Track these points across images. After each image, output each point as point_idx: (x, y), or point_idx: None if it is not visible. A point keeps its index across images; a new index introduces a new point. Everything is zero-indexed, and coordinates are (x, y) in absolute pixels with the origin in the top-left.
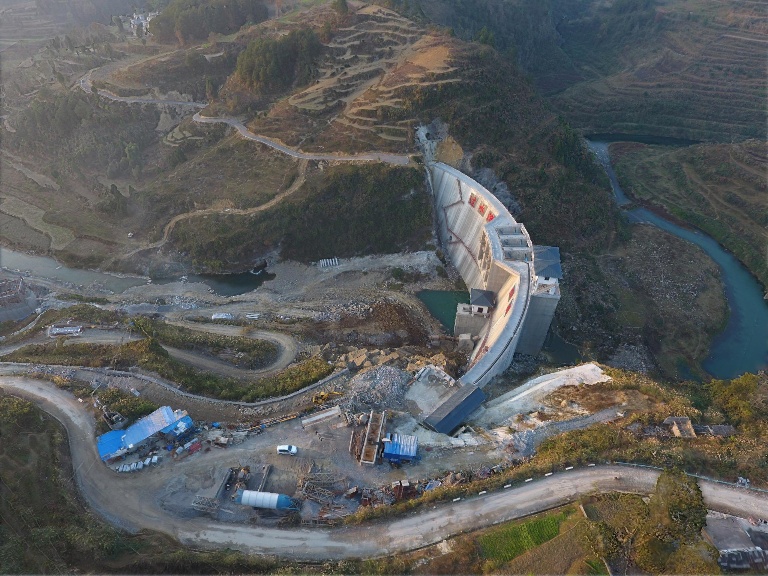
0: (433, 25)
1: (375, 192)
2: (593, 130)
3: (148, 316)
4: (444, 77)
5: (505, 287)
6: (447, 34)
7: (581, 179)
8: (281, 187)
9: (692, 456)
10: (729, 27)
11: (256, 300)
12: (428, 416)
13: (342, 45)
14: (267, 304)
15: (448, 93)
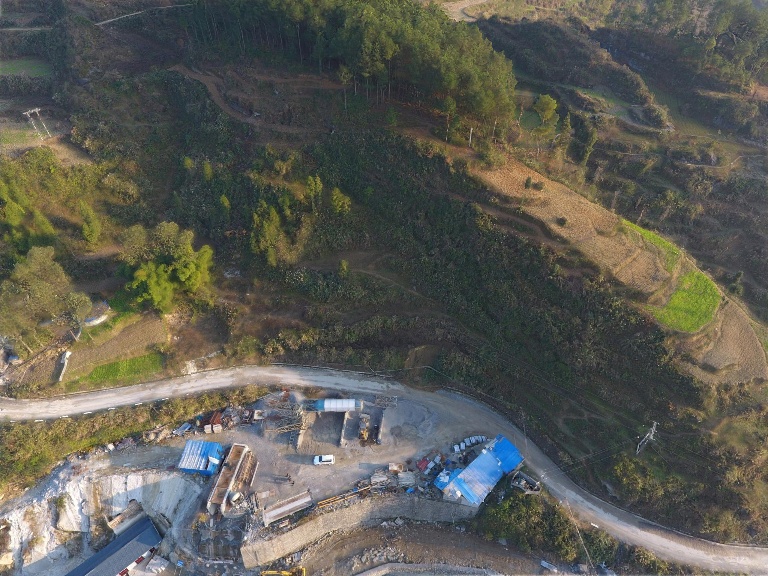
0: None
1: None
2: None
3: None
4: None
5: None
6: None
7: None
8: None
9: None
10: None
11: None
12: None
13: None
14: None
15: None
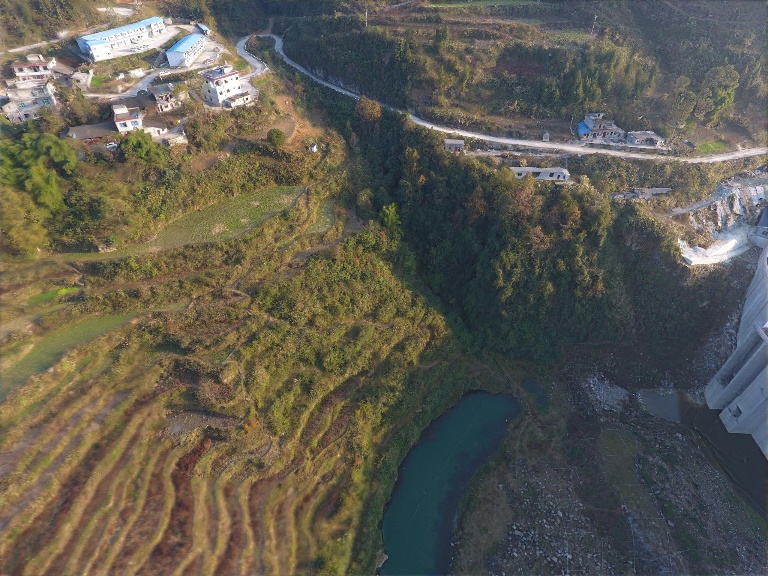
0: None
1: None
2: None
3: None
4: None
5: None
6: None
7: None
8: None
9: (651, 160)
10: None
11: None
12: None
13: None
14: None
15: None
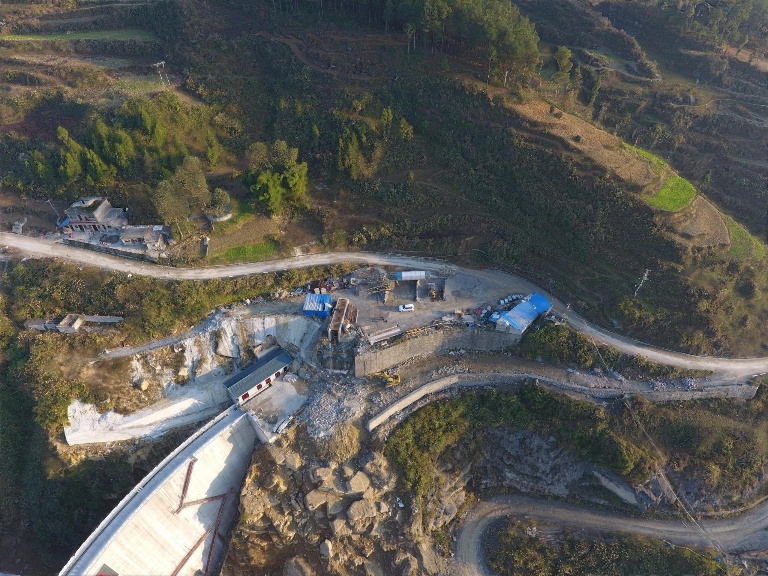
0: None
1: None
2: None
3: None
4: None
5: None
6: None
7: None
8: None
9: (104, 274)
10: None
11: None
12: None
13: None
14: None
15: None
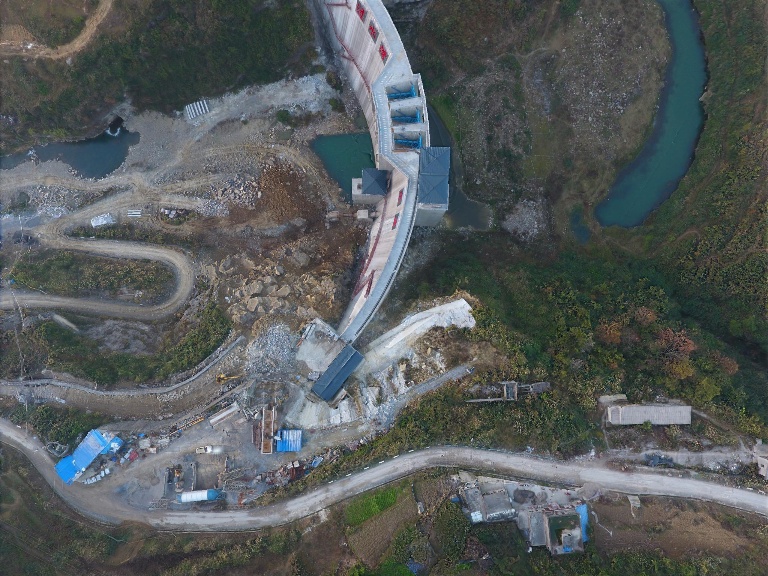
0: None
1: (223, 5)
2: None
3: (22, 237)
4: None
5: (398, 173)
6: None
7: None
8: (86, 3)
9: None
10: None
11: (130, 186)
12: (315, 384)
13: None
14: (144, 191)
15: None
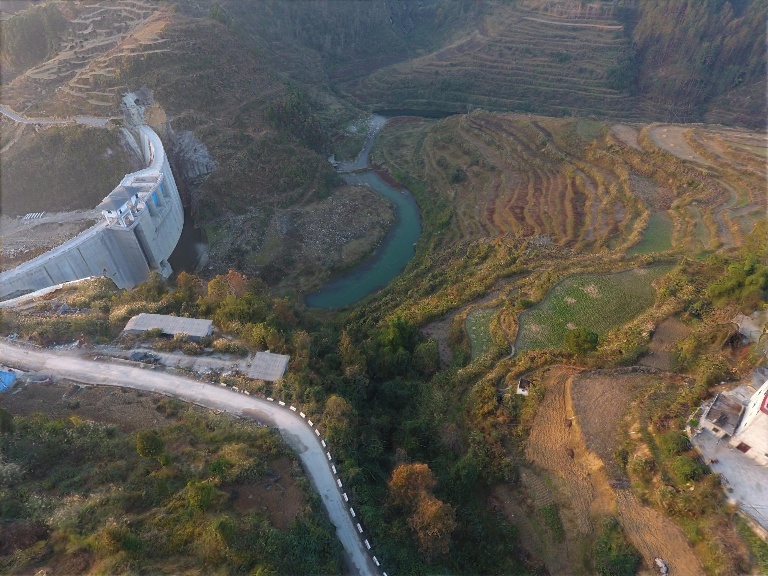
0: (164, 2)
1: (73, 151)
2: (384, 106)
3: None
4: (152, 48)
5: None
6: (172, 10)
7: (294, 143)
8: None
9: None
10: (532, 10)
11: None
12: None
13: (85, 21)
14: None
15: (154, 62)
